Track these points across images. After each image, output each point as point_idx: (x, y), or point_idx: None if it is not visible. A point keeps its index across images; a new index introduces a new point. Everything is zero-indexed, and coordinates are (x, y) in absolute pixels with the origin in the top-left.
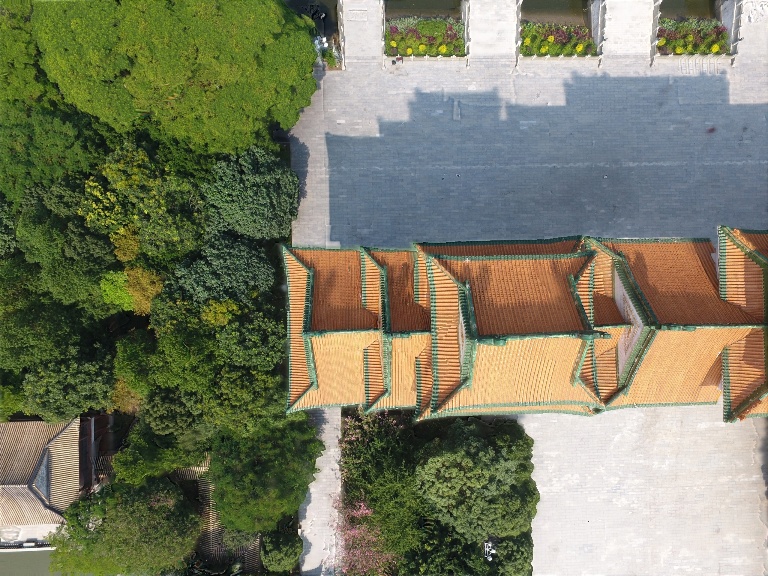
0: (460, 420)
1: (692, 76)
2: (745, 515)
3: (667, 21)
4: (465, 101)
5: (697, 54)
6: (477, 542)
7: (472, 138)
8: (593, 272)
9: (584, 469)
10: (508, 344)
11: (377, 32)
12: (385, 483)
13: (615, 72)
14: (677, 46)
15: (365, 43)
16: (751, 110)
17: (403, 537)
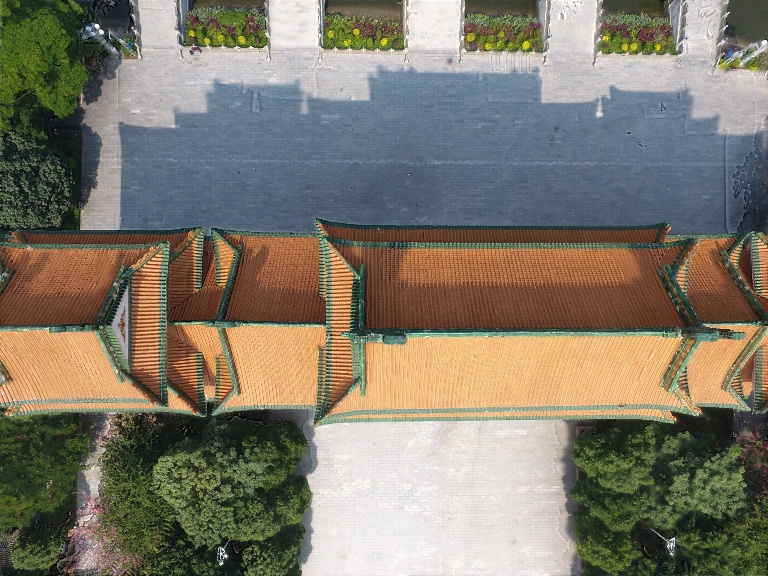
0: (214, 419)
1: (503, 73)
2: (543, 527)
3: (480, 17)
4: (265, 93)
5: (505, 51)
6: (207, 546)
7: (271, 131)
8: (219, 266)
9: (376, 474)
10: (22, 336)
11: (174, 21)
12: (116, 482)
13: (422, 67)
14: (487, 42)
15: (162, 32)
16: (564, 110)
17: (138, 538)
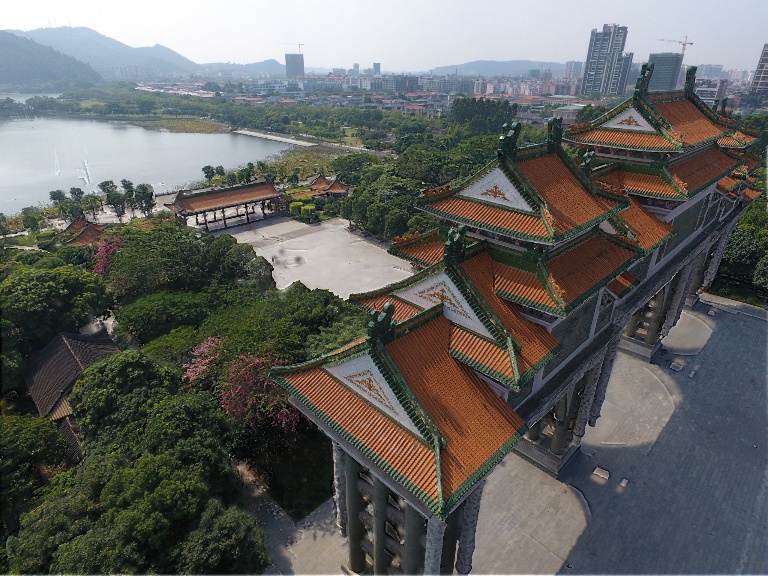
0: None
1: None
2: None
3: None
4: None
5: None
6: None
7: None
8: None
9: None
10: None
11: None
12: None
13: None
14: None
15: None
16: None
17: None
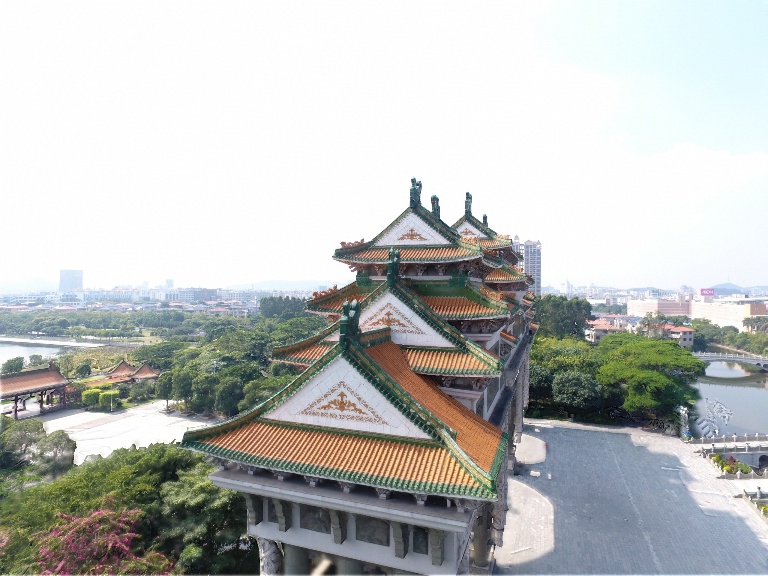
0: None
1: None
2: None
3: None
4: None
5: None
6: None
7: None
8: None
9: None
10: None
11: None
12: None
13: None
14: None
15: None
16: None
17: None
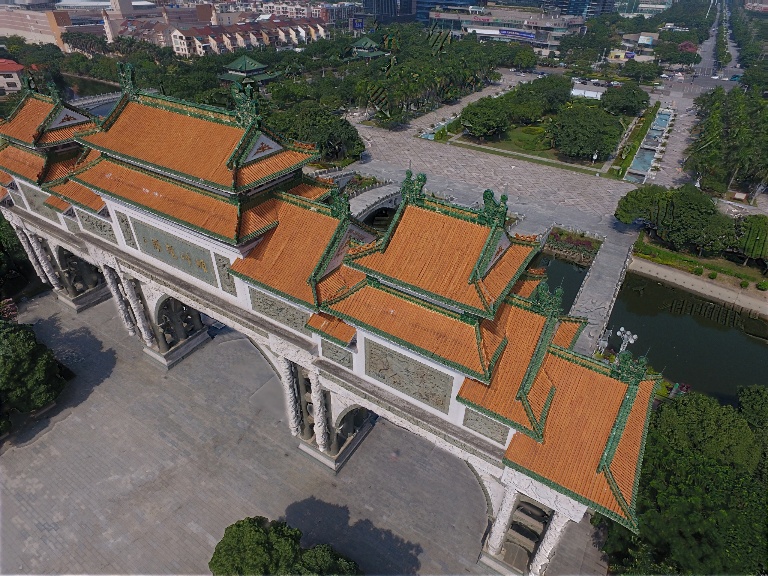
0: None
1: None
2: None
3: None
4: None
5: None
6: None
7: None
8: None
9: (54, 485)
10: None
11: None
12: None
13: None
14: None
15: None
16: None
17: None
